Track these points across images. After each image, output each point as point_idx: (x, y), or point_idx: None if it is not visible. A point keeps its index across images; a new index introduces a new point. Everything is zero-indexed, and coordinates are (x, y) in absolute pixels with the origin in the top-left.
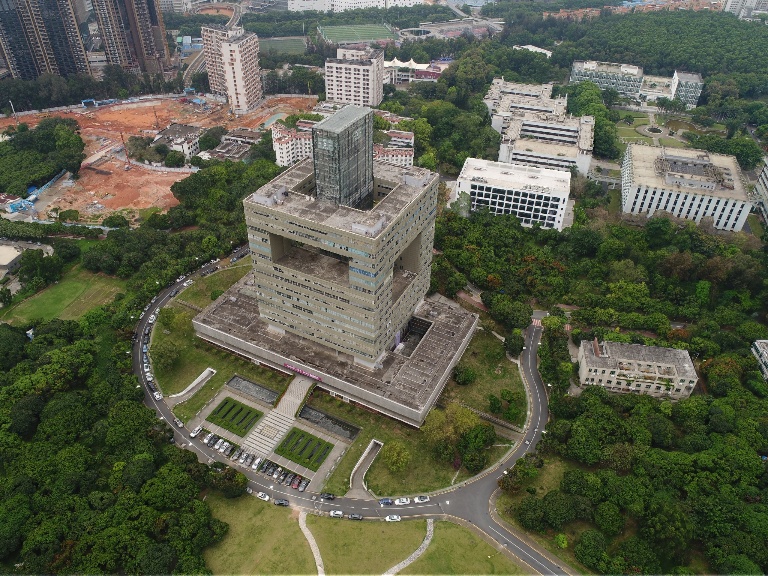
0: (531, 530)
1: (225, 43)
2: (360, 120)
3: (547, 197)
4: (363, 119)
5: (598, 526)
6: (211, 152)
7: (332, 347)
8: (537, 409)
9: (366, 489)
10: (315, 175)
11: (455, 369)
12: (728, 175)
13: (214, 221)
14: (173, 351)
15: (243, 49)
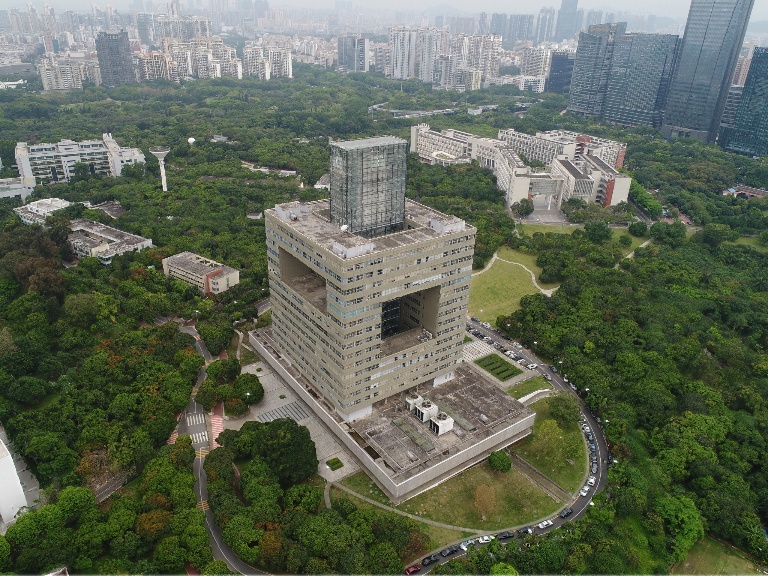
0: None
1: None
2: None
3: None
4: None
5: None
6: None
7: None
8: None
9: None
10: None
11: None
12: None
13: None
14: None
15: None
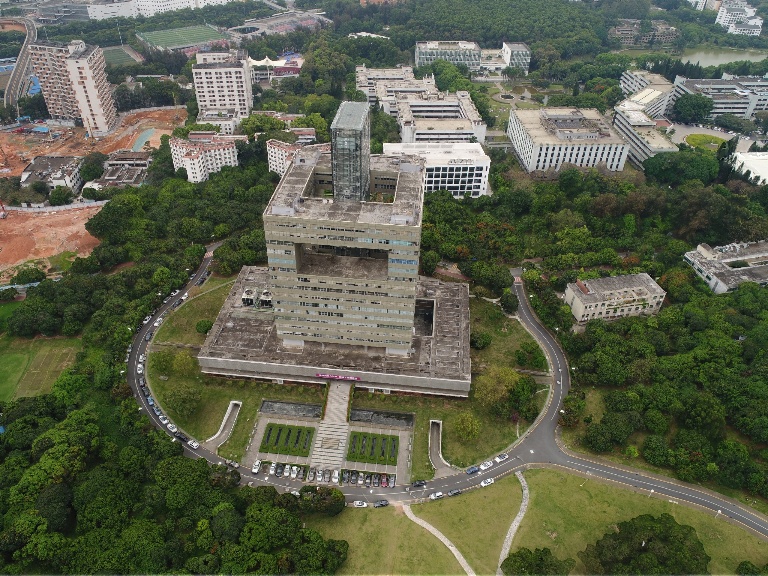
0: (601, 452)
1: (70, 60)
2: (367, 115)
3: (472, 168)
4: None
5: (651, 431)
6: (99, 181)
7: (364, 345)
8: (552, 352)
9: (449, 465)
10: (332, 176)
11: (471, 337)
12: (602, 125)
13: (150, 252)
14: (195, 393)
15: (92, 64)
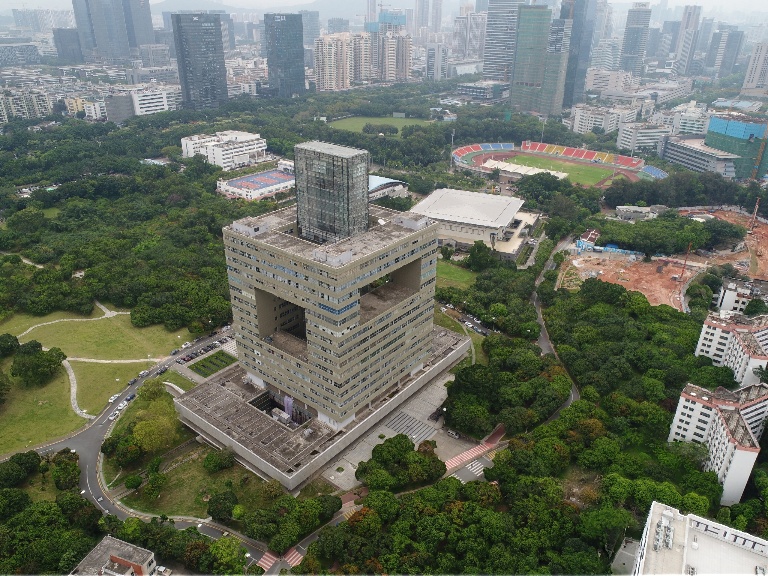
0: None
1: None
2: (325, 155)
3: None
4: (330, 157)
5: None
6: None
7: None
8: None
9: None
10: None
11: None
12: None
13: None
14: None
15: None
